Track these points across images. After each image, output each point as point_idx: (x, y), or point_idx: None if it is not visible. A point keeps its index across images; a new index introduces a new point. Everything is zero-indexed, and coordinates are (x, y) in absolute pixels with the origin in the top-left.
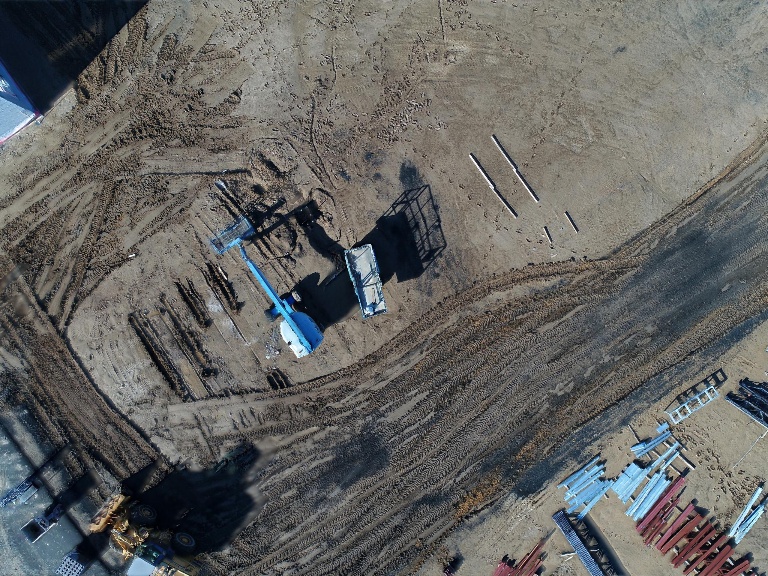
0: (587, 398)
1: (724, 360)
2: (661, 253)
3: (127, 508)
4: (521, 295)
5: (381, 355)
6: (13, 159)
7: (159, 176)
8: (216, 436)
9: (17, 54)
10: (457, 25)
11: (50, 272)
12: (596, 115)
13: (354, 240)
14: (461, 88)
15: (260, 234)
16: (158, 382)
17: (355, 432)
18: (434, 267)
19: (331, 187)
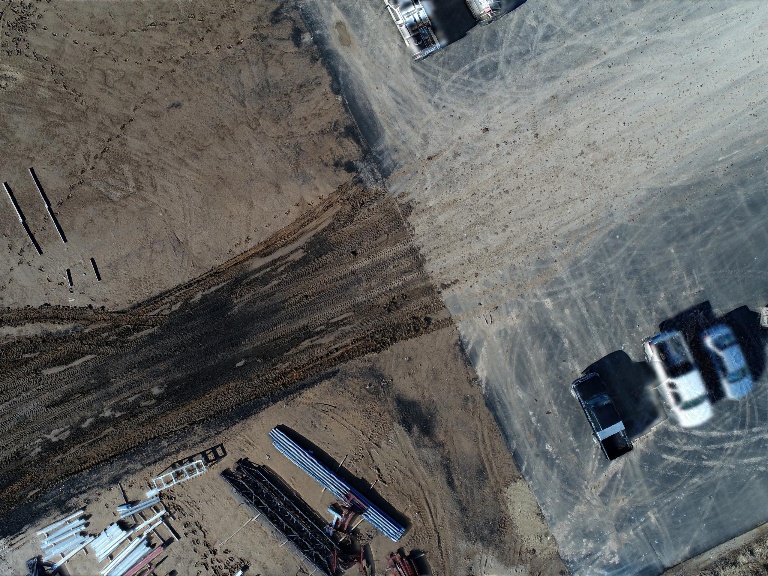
0: (81, 449)
1: (226, 435)
2: (182, 317)
3: None
4: (32, 334)
5: None
6: None
7: None
8: None
9: None
10: (14, 51)
11: None
12: (140, 166)
13: None
14: (7, 115)
15: None
16: None
17: None
18: None
19: None
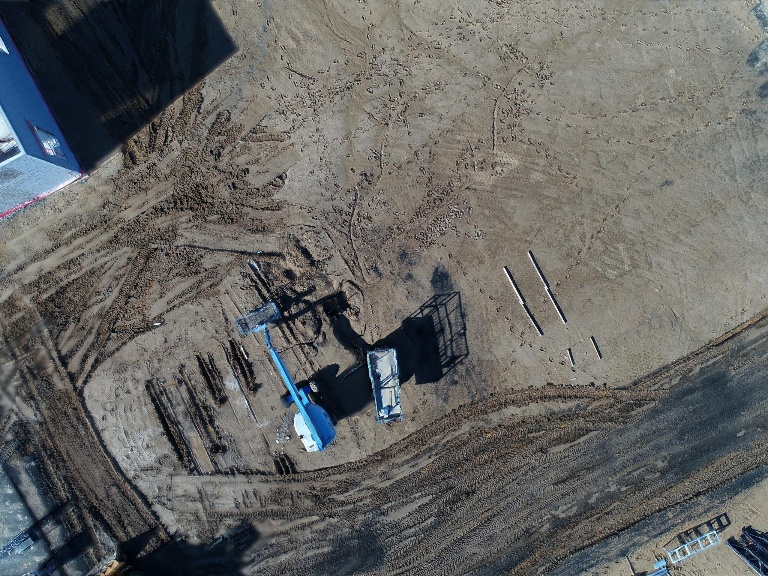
0: (588, 524)
1: (730, 505)
2: (681, 390)
3: (119, 573)
4: (536, 413)
5: (389, 454)
6: (53, 214)
7: (194, 249)
8: (216, 512)
9: (71, 112)
10: (509, 138)
11: (75, 330)
12: (635, 244)
13: (378, 336)
14: (504, 200)
15: (286, 319)
16: (166, 451)
17: (353, 527)
18: (453, 374)
19: (362, 281)
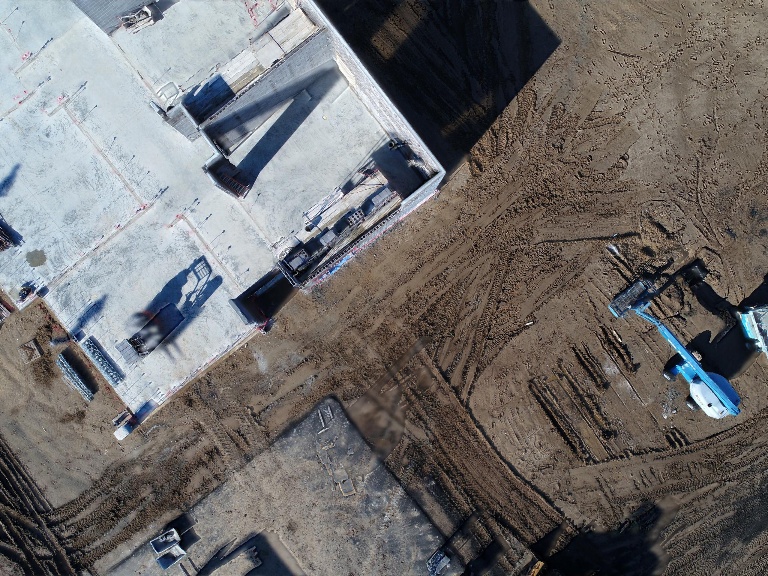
0: None
1: None
2: None
3: (541, 574)
4: None
5: None
6: (412, 235)
7: (552, 244)
8: (618, 497)
9: None
10: None
11: (451, 344)
12: None
13: (742, 296)
14: None
15: (651, 295)
16: (559, 447)
17: (754, 487)
18: None
19: (717, 245)
